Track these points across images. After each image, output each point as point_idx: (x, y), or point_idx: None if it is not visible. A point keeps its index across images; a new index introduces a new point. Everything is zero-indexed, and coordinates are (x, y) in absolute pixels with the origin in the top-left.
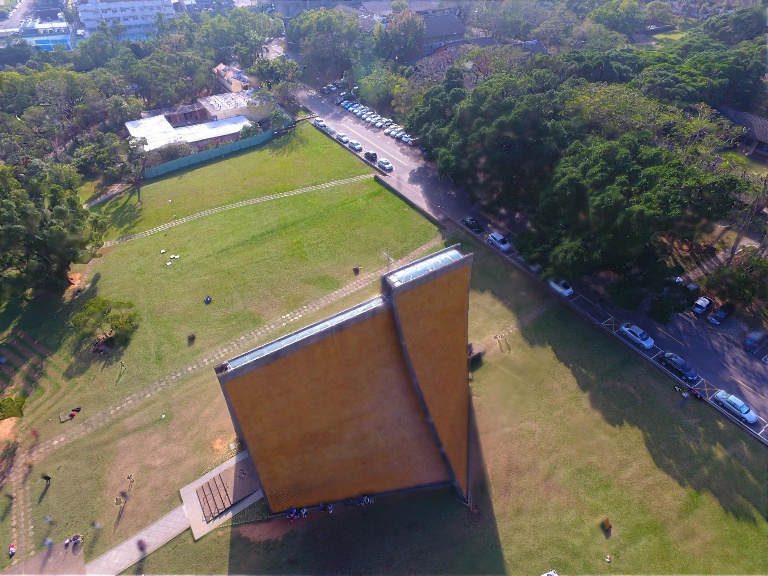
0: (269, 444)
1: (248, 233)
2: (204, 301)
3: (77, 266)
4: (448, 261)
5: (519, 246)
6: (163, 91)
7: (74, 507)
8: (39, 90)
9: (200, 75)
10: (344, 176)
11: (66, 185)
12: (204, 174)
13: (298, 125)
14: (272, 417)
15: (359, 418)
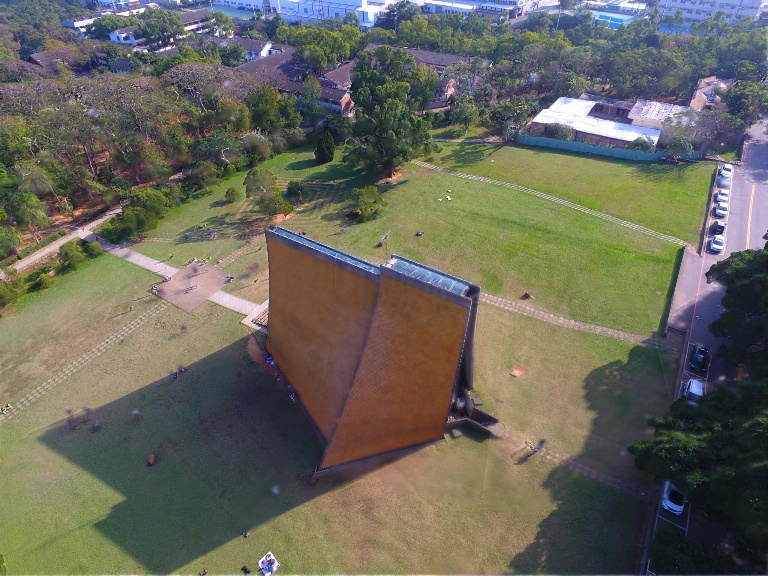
0: (279, 302)
1: (508, 215)
2: (417, 233)
3: (407, 170)
4: (459, 293)
5: (674, 405)
6: (619, 82)
7: (248, 267)
8: (525, 50)
9: (669, 79)
10: (658, 228)
11: (462, 120)
12: (554, 159)
13: (701, 163)
14: (286, 286)
15: (325, 342)
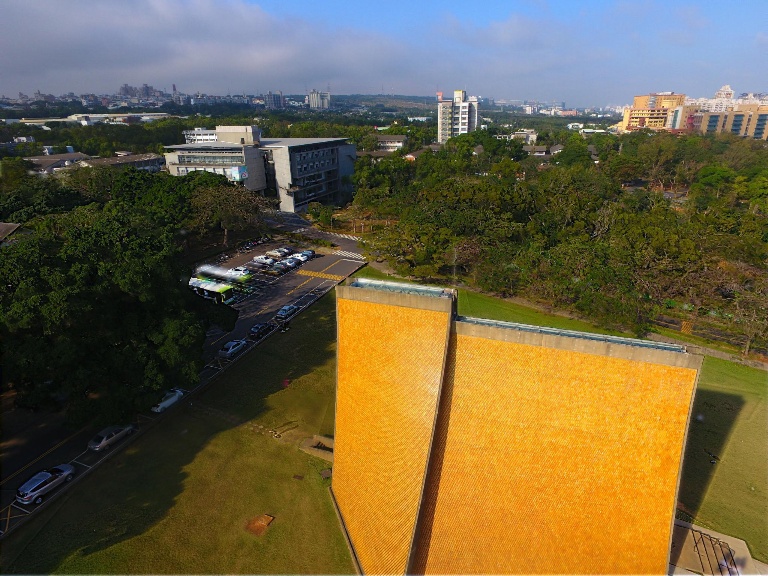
0: None
1: None
2: None
3: None
4: None
5: (118, 413)
6: None
7: None
8: None
9: None
10: None
11: None
12: None
13: None
14: None
15: None
